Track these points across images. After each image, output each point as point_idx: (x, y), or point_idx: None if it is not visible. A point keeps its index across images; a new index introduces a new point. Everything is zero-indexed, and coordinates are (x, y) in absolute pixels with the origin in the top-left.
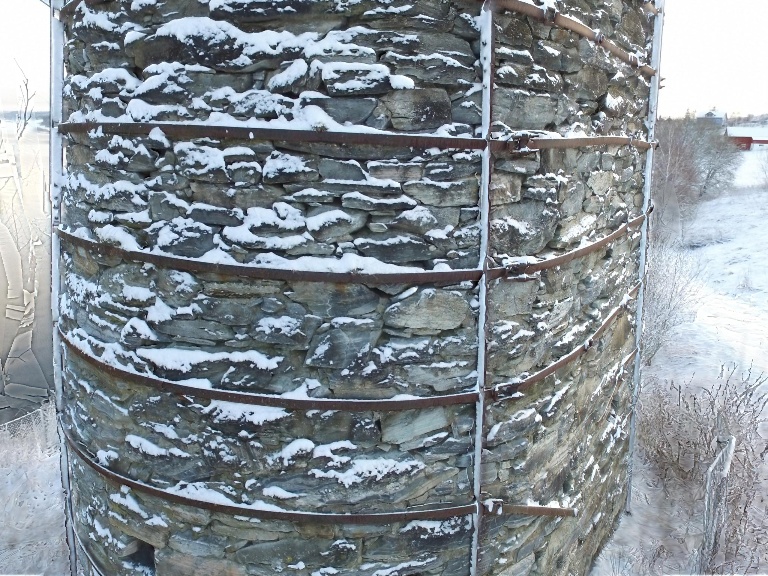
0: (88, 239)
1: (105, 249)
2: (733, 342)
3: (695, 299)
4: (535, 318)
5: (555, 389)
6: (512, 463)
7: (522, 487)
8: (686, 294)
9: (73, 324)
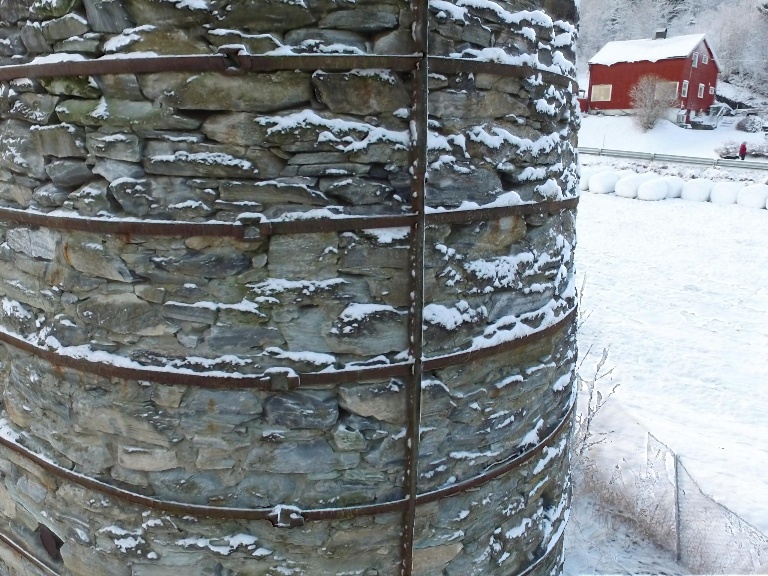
0: (525, 203)
1: (547, 206)
2: None
3: None
4: None
5: None
6: None
7: None
8: None
9: (479, 326)
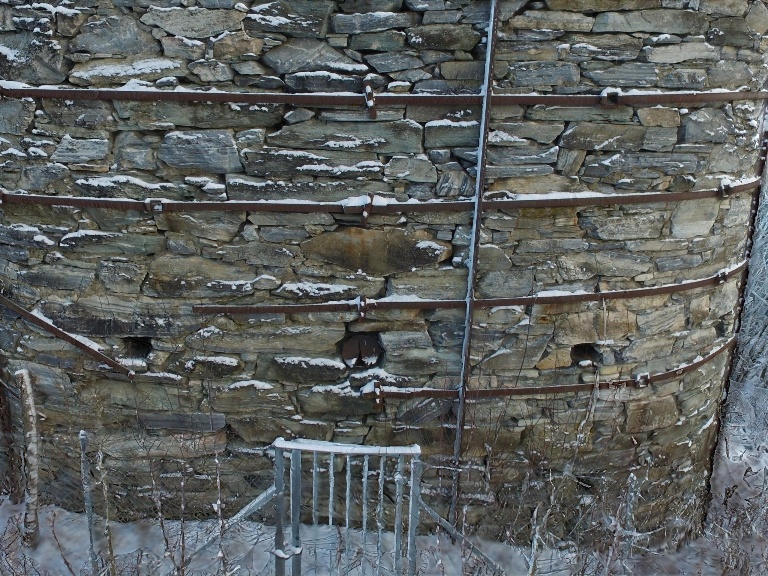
0: None
1: None
2: None
3: None
4: (26, 141)
5: (81, 227)
6: (22, 268)
7: (27, 293)
8: None
9: None
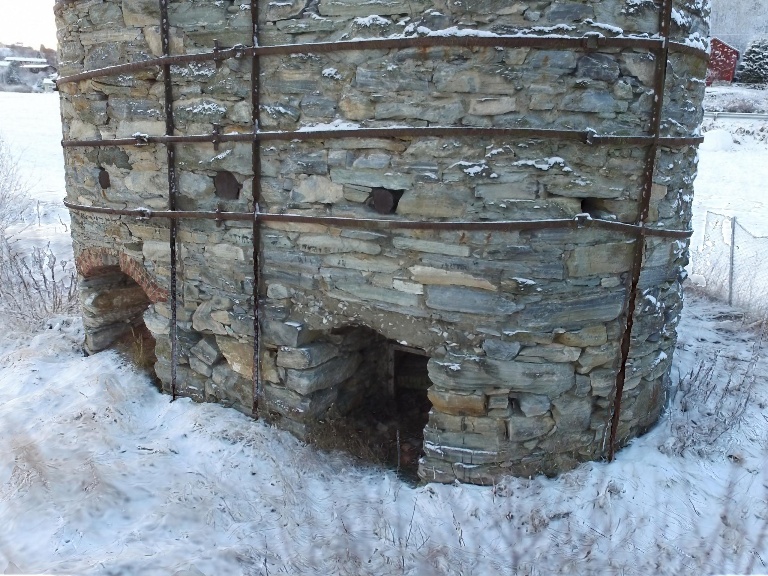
0: None
1: None
2: (30, 237)
3: (22, 193)
4: None
5: None
6: None
7: None
8: (6, 191)
9: None
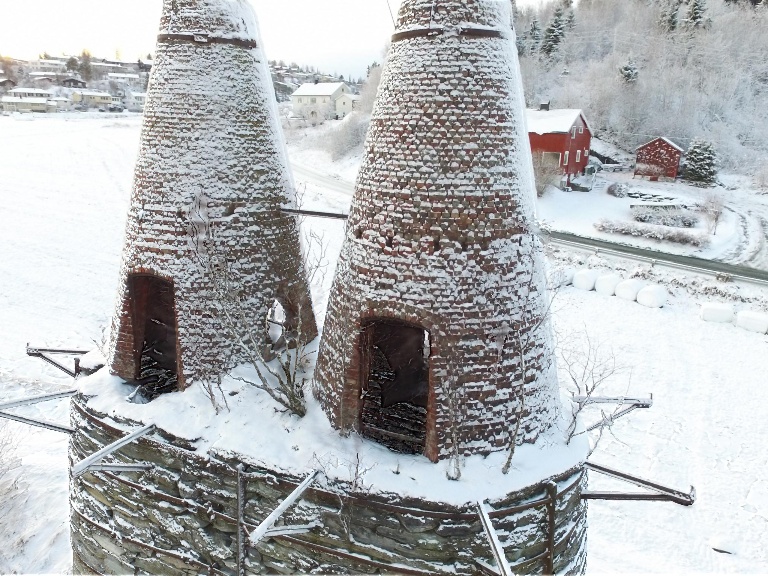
0: None
1: None
2: None
3: (13, 447)
4: None
5: None
6: None
7: None
8: None
9: None
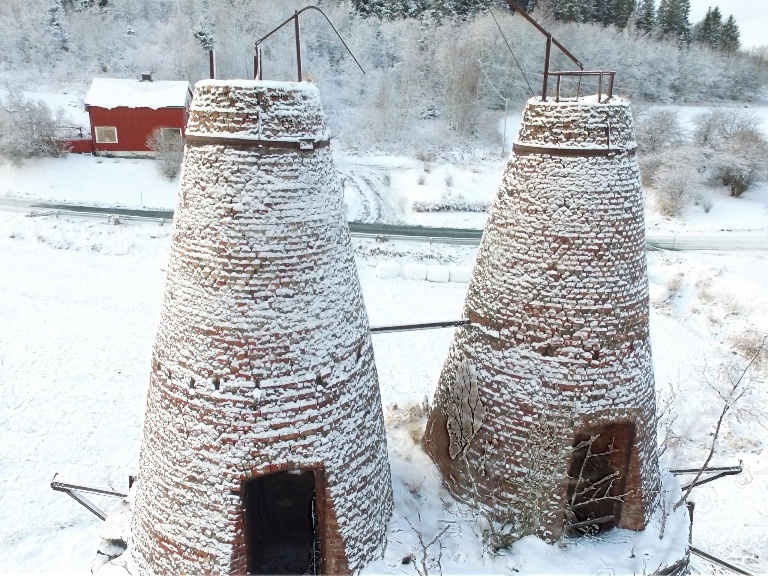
0: None
1: None
2: None
3: None
4: None
5: None
6: None
7: None
8: None
9: None
